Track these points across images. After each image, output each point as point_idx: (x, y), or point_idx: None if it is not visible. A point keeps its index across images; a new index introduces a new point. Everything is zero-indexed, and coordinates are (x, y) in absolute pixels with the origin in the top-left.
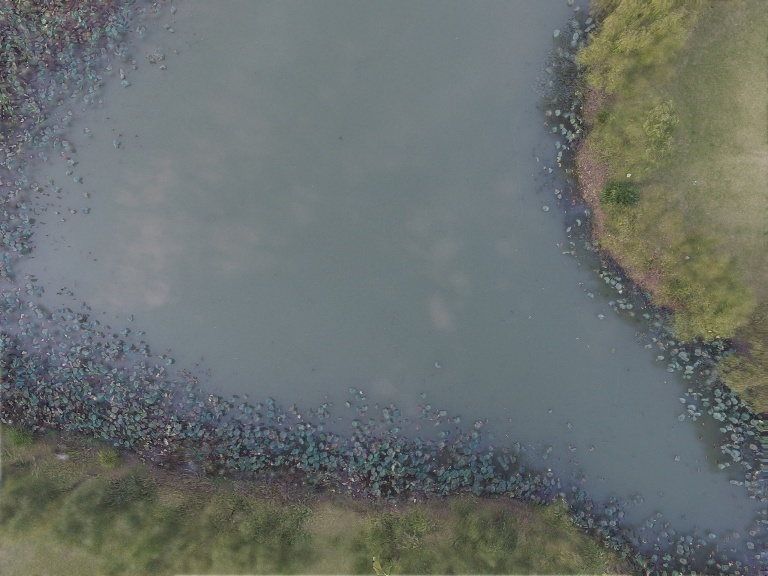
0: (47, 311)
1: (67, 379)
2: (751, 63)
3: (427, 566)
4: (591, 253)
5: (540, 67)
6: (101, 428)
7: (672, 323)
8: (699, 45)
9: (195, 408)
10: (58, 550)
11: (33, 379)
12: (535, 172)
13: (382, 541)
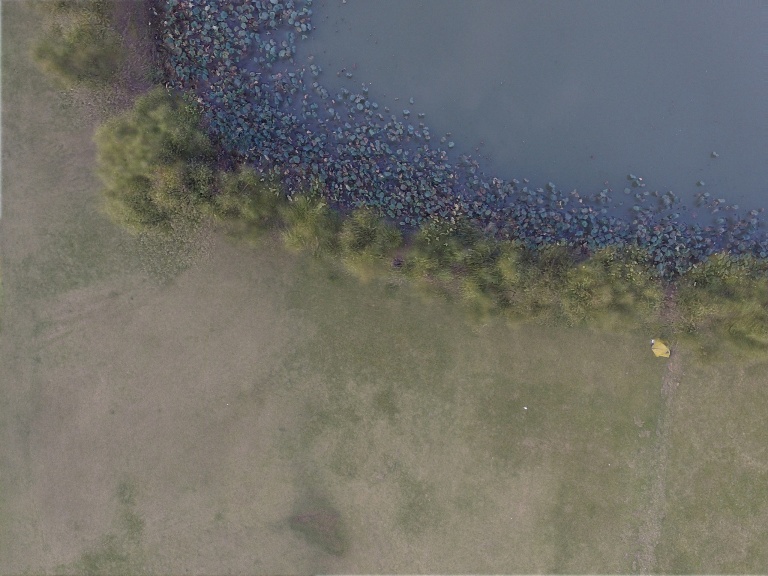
0: (332, 91)
1: (354, 157)
2: None
3: (704, 350)
4: None
5: None
6: (388, 206)
7: None
8: None
9: (481, 188)
10: (340, 329)
11: (321, 156)
12: None
13: (660, 325)
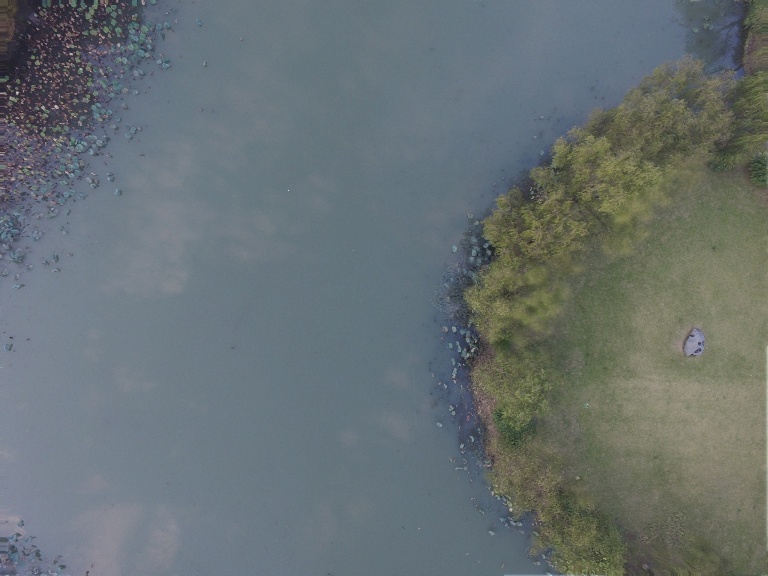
0: None
1: None
2: (647, 287)
3: None
4: (484, 469)
5: (439, 281)
6: None
7: (560, 543)
8: (596, 266)
9: None
10: None
11: None
12: (431, 387)
13: None
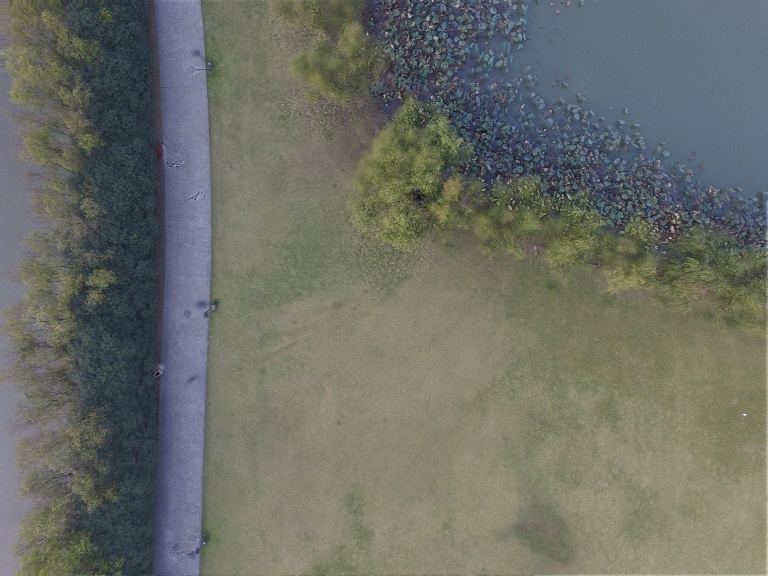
0: (549, 101)
1: (574, 167)
2: None
3: None
4: None
5: None
6: (608, 215)
7: None
8: None
9: (700, 197)
10: (559, 338)
11: (542, 166)
12: None
13: None
